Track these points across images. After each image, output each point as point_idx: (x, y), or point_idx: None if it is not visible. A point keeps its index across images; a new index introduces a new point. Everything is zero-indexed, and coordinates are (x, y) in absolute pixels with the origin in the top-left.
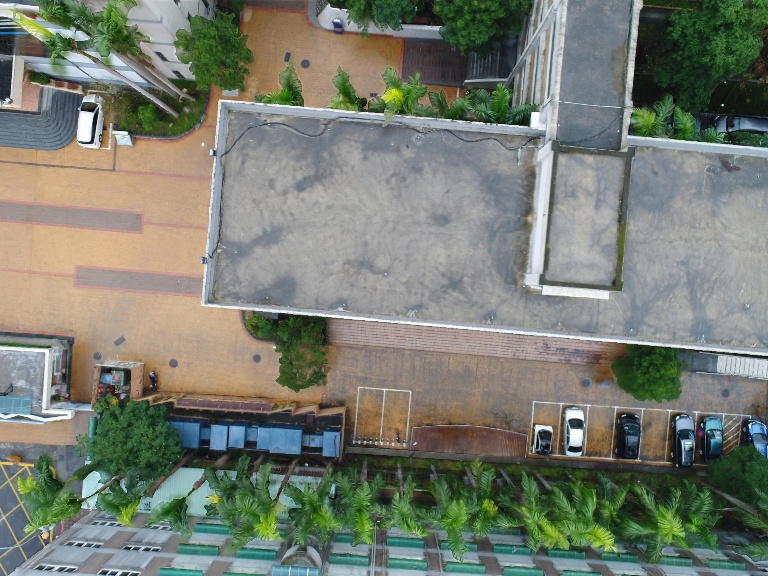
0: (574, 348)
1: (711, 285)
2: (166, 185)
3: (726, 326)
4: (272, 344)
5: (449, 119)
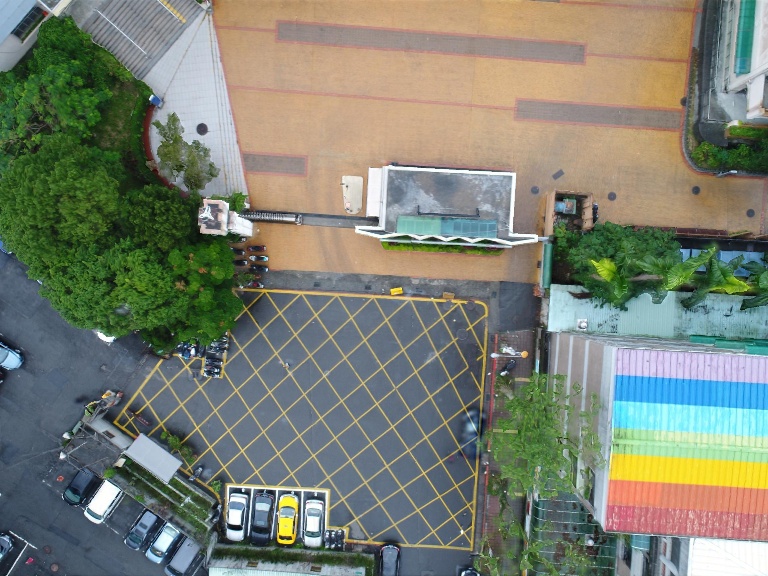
0: None
1: None
2: (611, 15)
3: None
4: (711, 176)
5: None
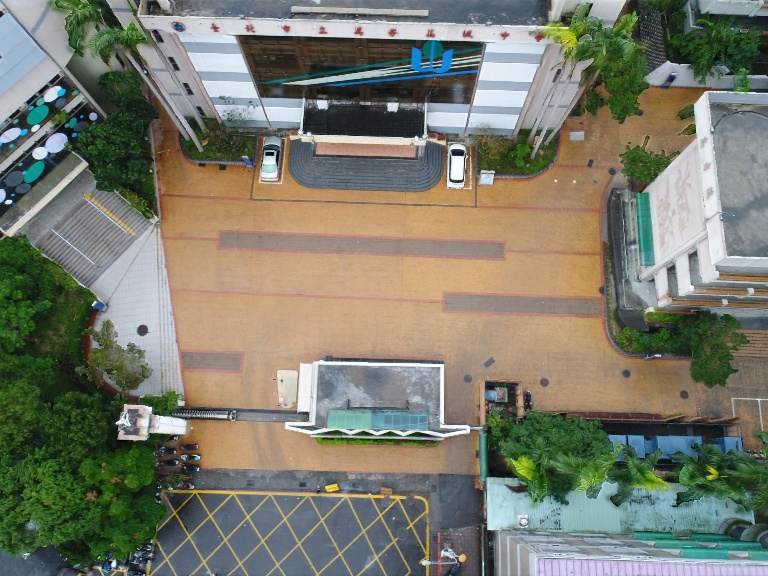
0: None
1: None
2: (524, 217)
3: None
4: (639, 359)
5: None
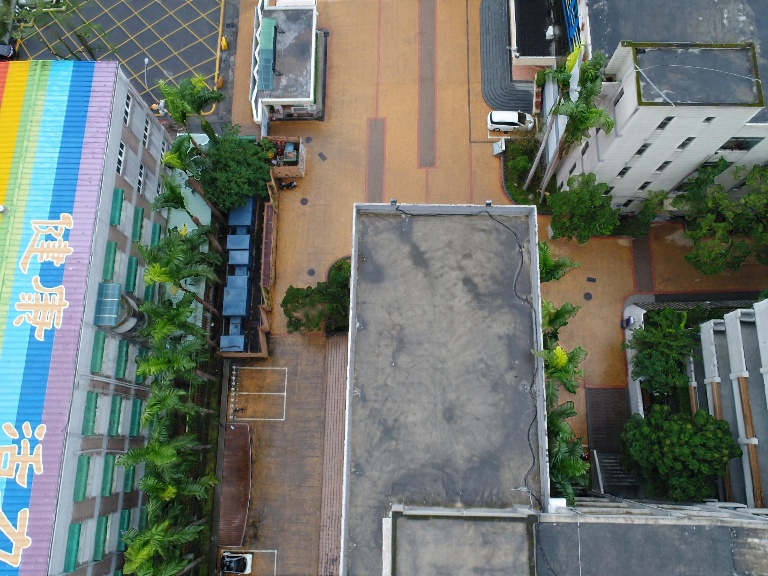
0: None
1: None
2: (462, 185)
3: None
4: None
5: None
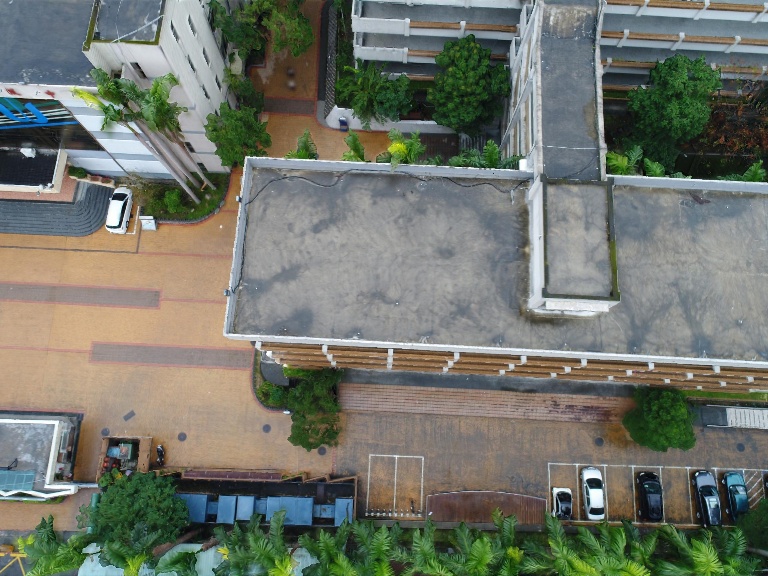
0: (583, 405)
1: (703, 304)
2: (185, 264)
3: (724, 341)
4: (282, 413)
5: (448, 166)
